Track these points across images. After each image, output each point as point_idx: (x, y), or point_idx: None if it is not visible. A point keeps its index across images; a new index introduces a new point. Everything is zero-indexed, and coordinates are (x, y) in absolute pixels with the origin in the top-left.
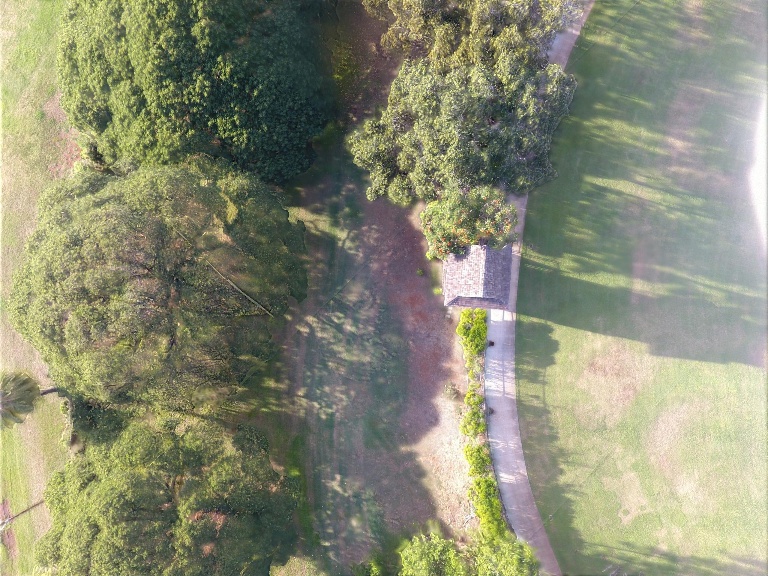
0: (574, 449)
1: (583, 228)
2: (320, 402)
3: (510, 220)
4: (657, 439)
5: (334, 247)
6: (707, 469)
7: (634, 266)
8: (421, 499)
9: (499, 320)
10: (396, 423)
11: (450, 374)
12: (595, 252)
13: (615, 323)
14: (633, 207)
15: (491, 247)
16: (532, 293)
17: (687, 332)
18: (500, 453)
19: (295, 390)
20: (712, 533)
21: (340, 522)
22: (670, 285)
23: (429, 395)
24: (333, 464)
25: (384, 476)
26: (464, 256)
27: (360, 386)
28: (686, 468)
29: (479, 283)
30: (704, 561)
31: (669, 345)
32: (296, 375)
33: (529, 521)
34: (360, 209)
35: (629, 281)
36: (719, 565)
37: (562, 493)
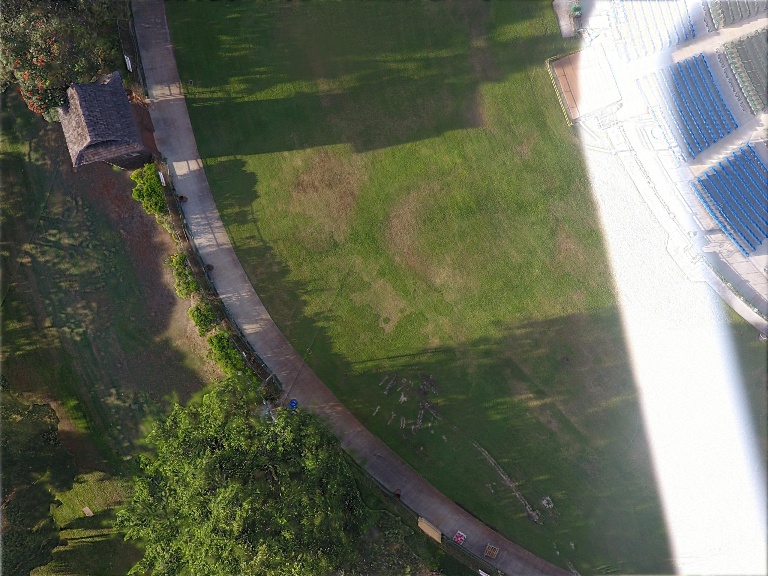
0: (311, 276)
1: (242, 44)
2: (69, 325)
3: (55, 39)
4: (396, 237)
5: (23, 165)
6: (458, 250)
7: (312, 67)
8: (191, 381)
9: (185, 172)
10: (143, 317)
11: (164, 247)
12: (264, 66)
13: (310, 133)
14: (290, 3)
15: (79, 83)
16: (210, 132)
17: (390, 117)
18: (235, 306)
19: (42, 323)
20: (482, 311)
21: (132, 432)
22: (359, 74)
23: (157, 277)
24: (105, 380)
25: (150, 373)
26: (66, 106)
27: (98, 295)
28: (435, 256)
29: (83, 127)
30: (481, 340)
31: (375, 137)
32: (36, 308)
33: (289, 362)
34: (30, 115)
35: (312, 84)
36: (498, 339)
37: (313, 323)
